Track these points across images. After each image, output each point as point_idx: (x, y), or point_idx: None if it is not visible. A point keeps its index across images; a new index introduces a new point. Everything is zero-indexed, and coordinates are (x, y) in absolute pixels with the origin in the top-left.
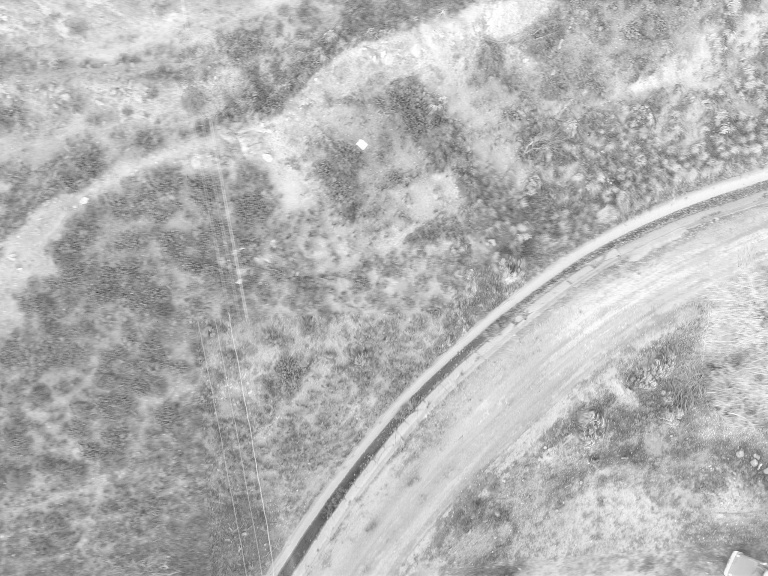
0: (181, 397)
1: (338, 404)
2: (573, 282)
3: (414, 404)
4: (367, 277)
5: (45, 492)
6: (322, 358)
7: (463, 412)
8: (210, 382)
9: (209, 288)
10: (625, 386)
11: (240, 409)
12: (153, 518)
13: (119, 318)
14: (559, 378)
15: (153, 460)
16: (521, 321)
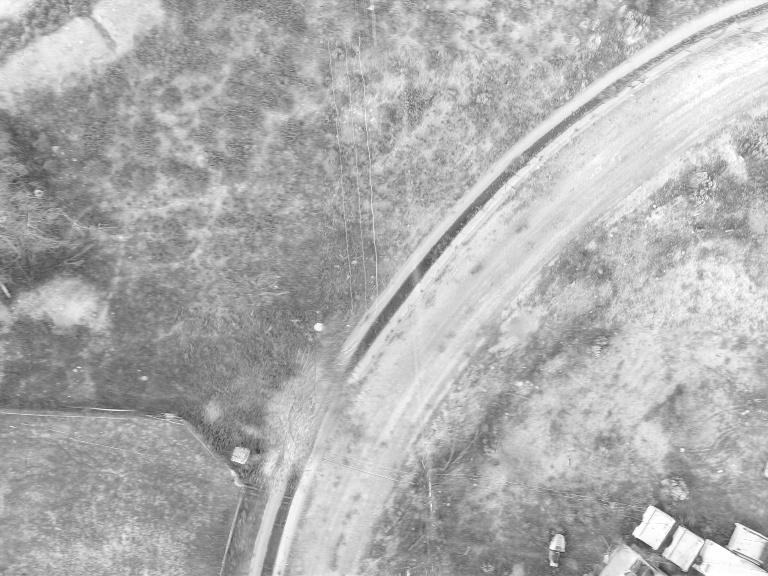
0: (306, 116)
1: (456, 142)
2: (692, 50)
3: (526, 158)
4: (495, 18)
5: (167, 196)
6: (445, 93)
7: (576, 165)
8: (335, 104)
9: (342, 9)
10: (738, 153)
11: (362, 134)
12: (267, 236)
13: (253, 29)
14: (673, 139)
15: (273, 176)
16: (638, 84)
